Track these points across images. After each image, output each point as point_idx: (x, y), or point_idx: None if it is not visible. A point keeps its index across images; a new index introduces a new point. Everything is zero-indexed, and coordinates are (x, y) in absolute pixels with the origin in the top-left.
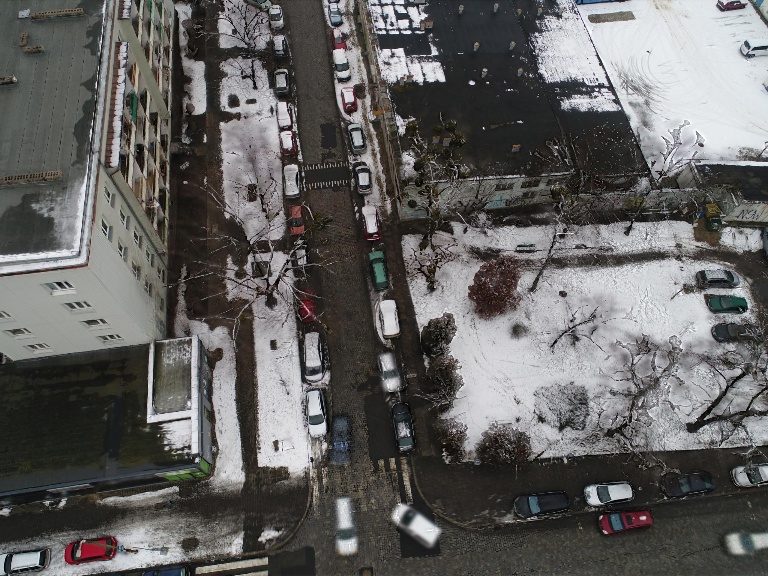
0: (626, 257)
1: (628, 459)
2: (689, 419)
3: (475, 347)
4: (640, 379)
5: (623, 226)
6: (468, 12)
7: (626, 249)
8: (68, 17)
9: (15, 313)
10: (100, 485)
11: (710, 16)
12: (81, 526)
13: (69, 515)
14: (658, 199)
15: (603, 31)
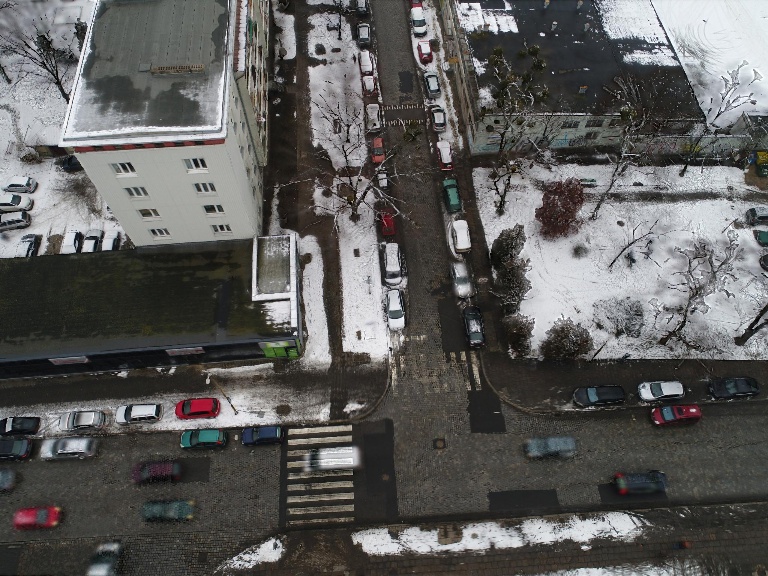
0: (680, 195)
1: (679, 365)
2: (737, 334)
3: (539, 264)
4: (696, 279)
5: (678, 169)
6: None
7: (680, 189)
8: None
9: (152, 190)
10: (205, 358)
11: None
12: (189, 390)
13: (178, 380)
14: (712, 145)
15: (662, 1)
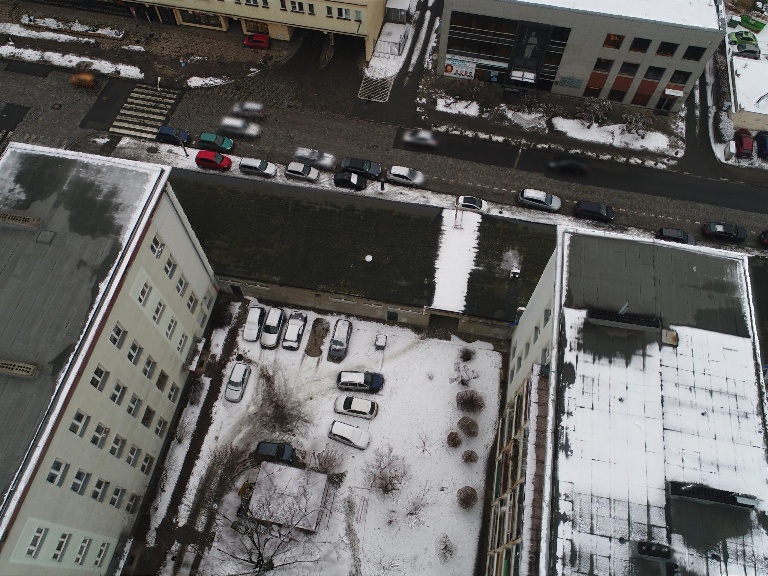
0: None
1: None
2: None
3: None
4: None
5: None
6: None
7: None
8: None
9: None
10: None
11: None
12: None
13: None
14: None
15: None
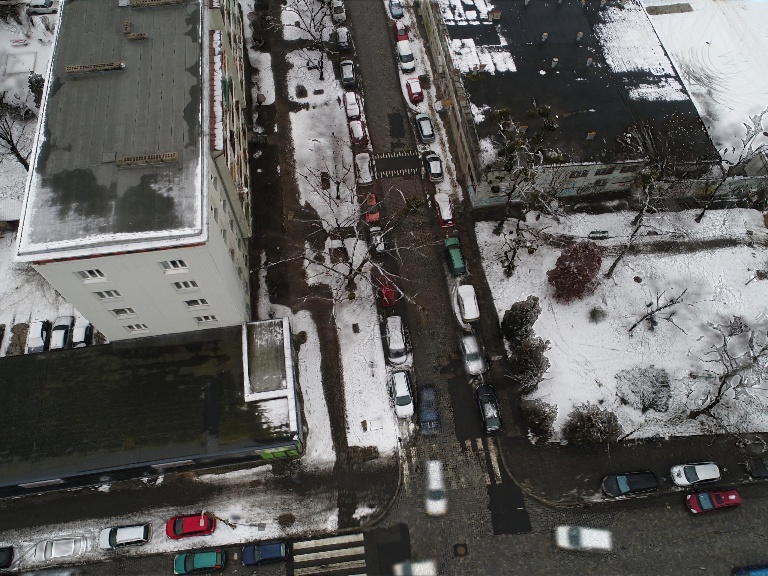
0: (698, 244)
1: (712, 440)
2: None
3: (554, 331)
4: (733, 359)
5: (693, 213)
6: (533, 3)
7: (697, 236)
8: (167, 5)
9: (125, 292)
10: None
11: (767, 8)
12: (179, 502)
13: (167, 492)
14: (729, 187)
15: (662, 23)
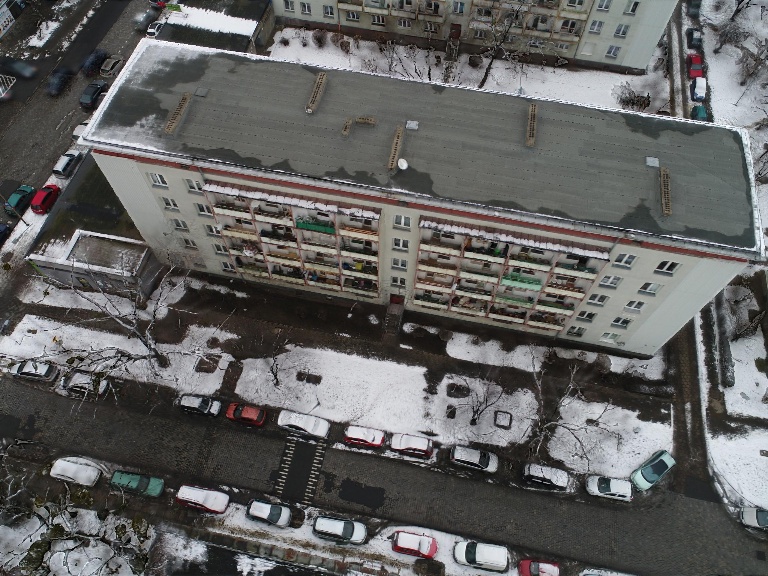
0: None
1: None
2: None
3: None
4: None
5: None
6: None
7: None
8: None
9: None
10: None
11: None
12: None
13: None
14: None
15: None
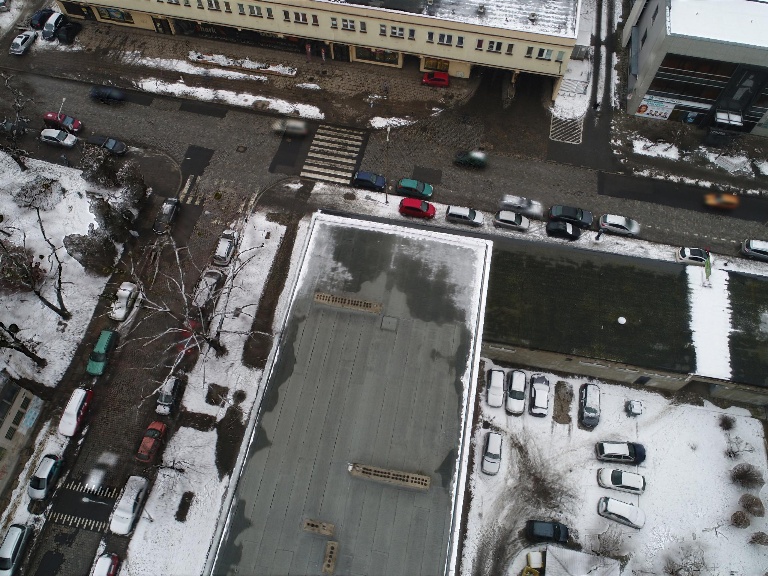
0: None
1: None
2: None
3: None
4: None
5: None
6: None
7: None
8: None
9: None
10: None
11: None
12: None
13: None
14: None
15: None
